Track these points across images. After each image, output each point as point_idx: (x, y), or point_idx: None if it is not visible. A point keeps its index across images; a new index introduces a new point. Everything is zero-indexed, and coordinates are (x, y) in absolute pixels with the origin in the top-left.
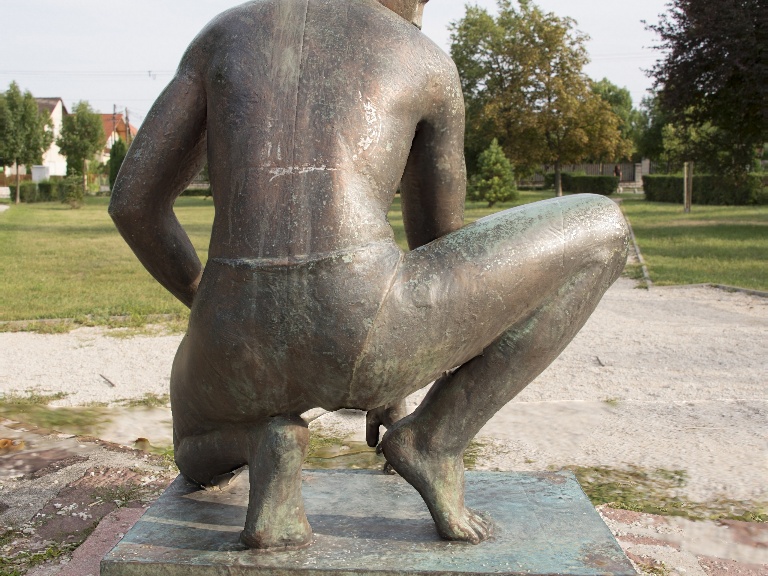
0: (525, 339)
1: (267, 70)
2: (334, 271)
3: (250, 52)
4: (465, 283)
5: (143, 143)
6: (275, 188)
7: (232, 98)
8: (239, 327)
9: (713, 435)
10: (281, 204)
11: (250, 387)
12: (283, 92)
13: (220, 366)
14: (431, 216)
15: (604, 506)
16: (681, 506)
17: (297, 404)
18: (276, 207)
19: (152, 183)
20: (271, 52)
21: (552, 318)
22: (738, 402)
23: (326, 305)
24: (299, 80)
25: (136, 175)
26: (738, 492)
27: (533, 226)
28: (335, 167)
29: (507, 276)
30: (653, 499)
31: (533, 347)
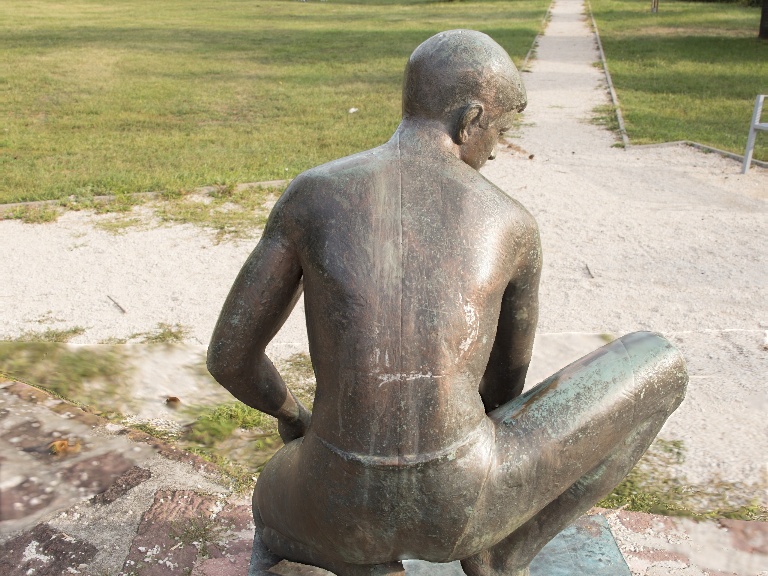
0: (594, 484)
1: (370, 270)
2: (440, 469)
3: (351, 246)
4: (551, 460)
5: (240, 310)
6: (384, 393)
7: (337, 296)
8: (352, 512)
9: (703, 388)
10: (390, 409)
11: (360, 554)
12: (387, 295)
13: (333, 538)
14: (506, 354)
15: (620, 510)
16: (682, 492)
17: (398, 558)
18: (386, 411)
19: (250, 345)
20: (372, 248)
21: (619, 465)
22: (723, 335)
23: (433, 498)
24: (402, 281)
25: (235, 340)
26: (730, 470)
27: (609, 393)
28: (440, 374)
29: (586, 446)
30: (656, 481)
31: (601, 489)
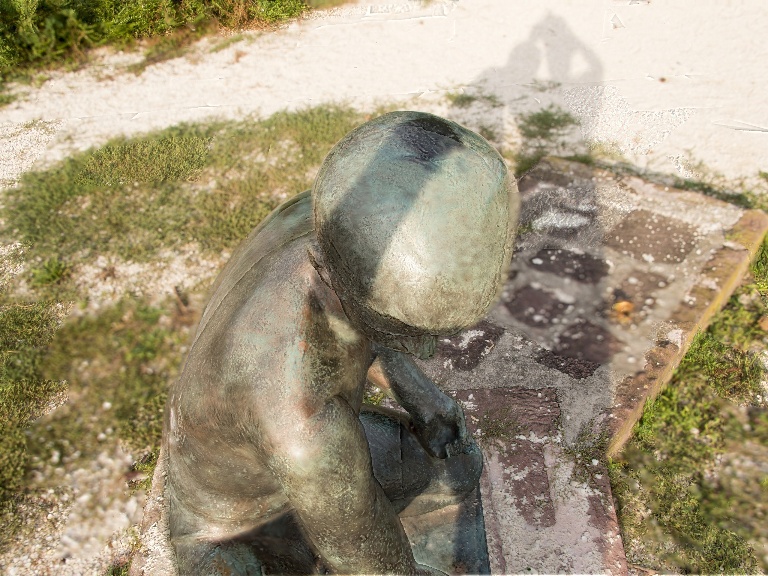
0: None
1: None
2: None
3: None
4: None
5: None
6: None
7: None
8: None
9: None
10: None
11: None
12: None
13: None
14: None
15: None
16: None
17: None
18: None
19: None
20: None
21: None
22: None
23: None
24: None
25: None
26: None
27: None
28: None
29: None
30: None
31: None
